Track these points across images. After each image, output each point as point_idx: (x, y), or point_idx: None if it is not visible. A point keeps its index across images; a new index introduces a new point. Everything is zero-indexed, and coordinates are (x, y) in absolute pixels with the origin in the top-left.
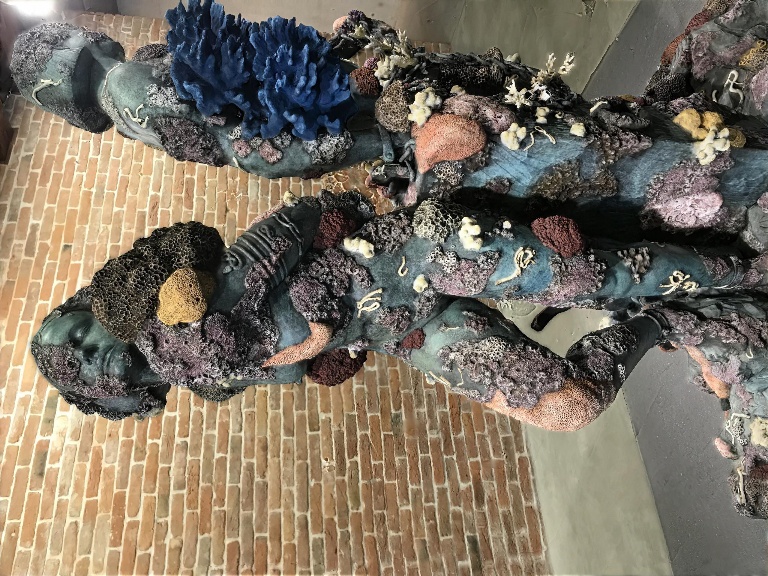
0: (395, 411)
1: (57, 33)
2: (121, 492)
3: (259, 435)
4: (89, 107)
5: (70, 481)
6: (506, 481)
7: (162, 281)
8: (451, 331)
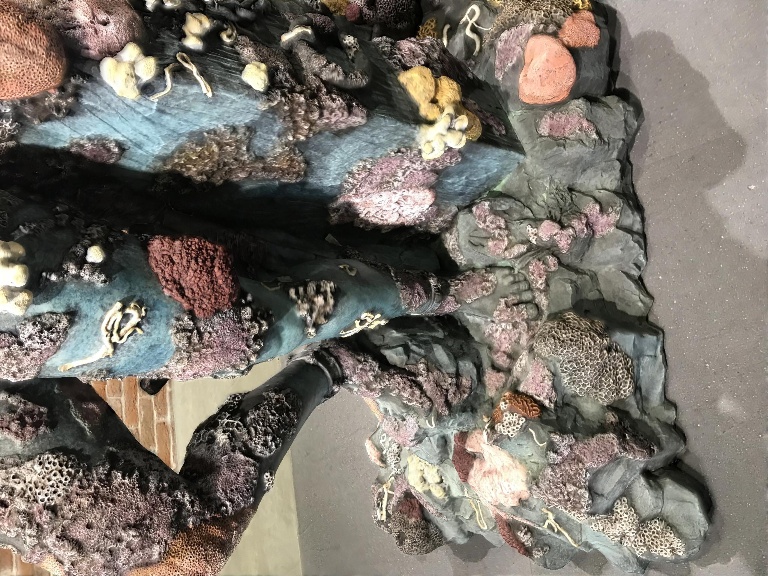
0: None
1: None
2: None
3: None
4: None
5: None
6: (137, 396)
7: None
8: None
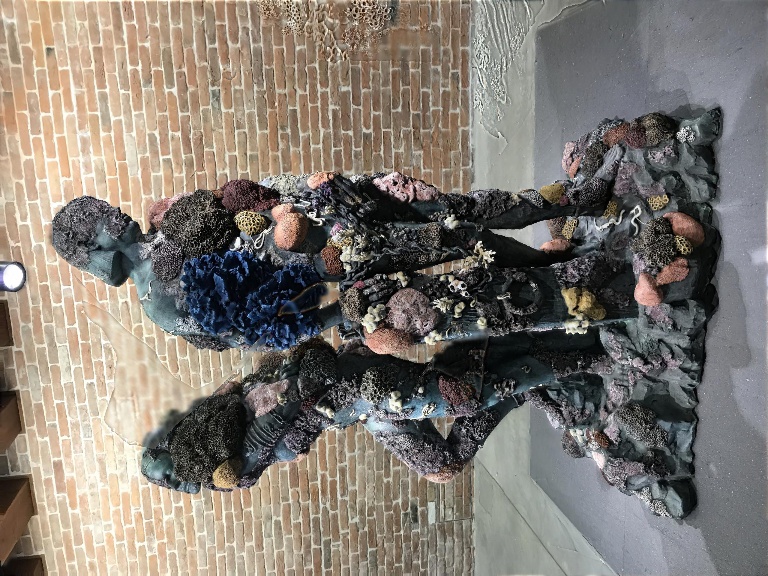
0: None
1: (86, 232)
2: None
3: None
4: (124, 279)
5: None
6: (452, 263)
7: (213, 471)
8: (382, 424)
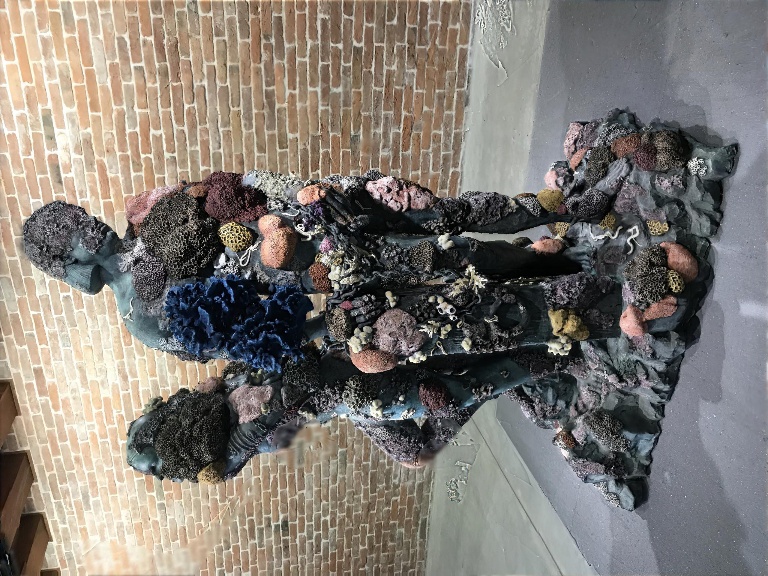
0: (354, 134)
1: (61, 246)
2: (129, 196)
3: (236, 152)
4: None
5: (85, 188)
6: (437, 189)
7: None
8: None
